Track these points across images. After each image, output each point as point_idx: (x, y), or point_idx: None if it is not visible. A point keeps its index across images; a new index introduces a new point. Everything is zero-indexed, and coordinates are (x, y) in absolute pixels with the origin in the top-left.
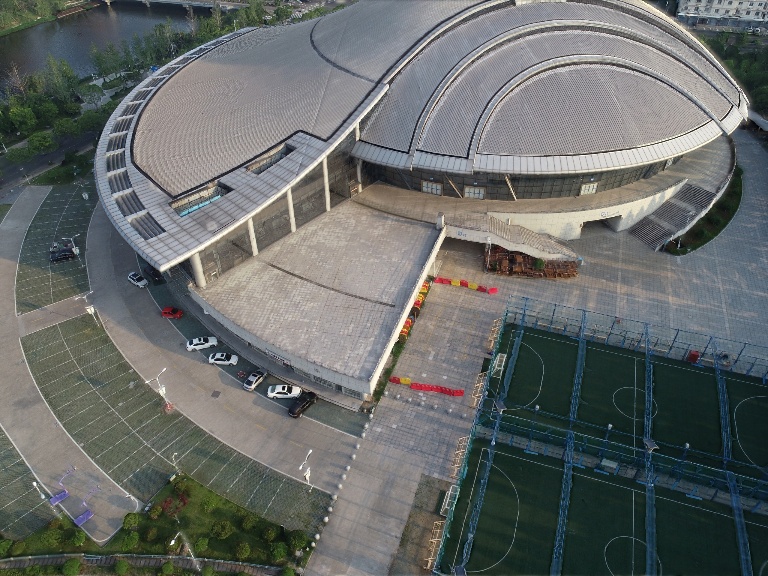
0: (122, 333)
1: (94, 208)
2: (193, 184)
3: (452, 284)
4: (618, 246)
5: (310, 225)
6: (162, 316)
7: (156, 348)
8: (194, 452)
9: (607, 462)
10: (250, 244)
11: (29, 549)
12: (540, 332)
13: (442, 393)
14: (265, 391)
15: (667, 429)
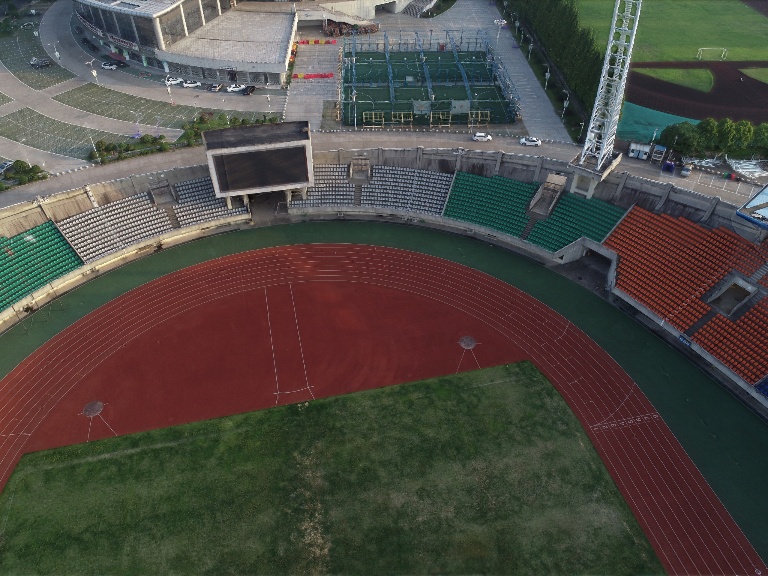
0: (118, 87)
1: (42, 45)
2: None
3: (309, 43)
4: (397, 19)
5: (213, 21)
6: (139, 77)
7: (146, 88)
8: (200, 113)
9: (408, 78)
10: (183, 27)
11: (136, 149)
12: (365, 53)
13: (322, 77)
14: (225, 91)
15: (434, 71)
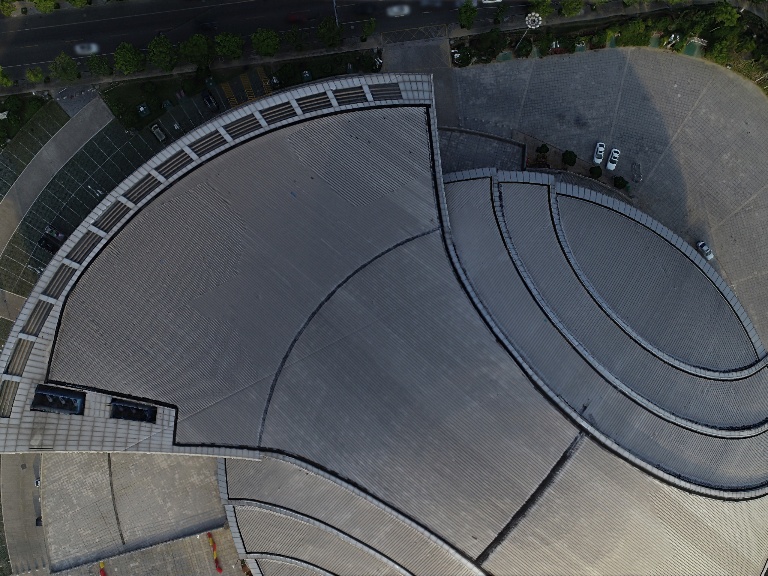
0: None
1: None
2: (70, 378)
3: None
4: None
5: None
6: None
7: None
8: None
9: None
10: None
11: None
12: None
13: None
14: None
15: None
